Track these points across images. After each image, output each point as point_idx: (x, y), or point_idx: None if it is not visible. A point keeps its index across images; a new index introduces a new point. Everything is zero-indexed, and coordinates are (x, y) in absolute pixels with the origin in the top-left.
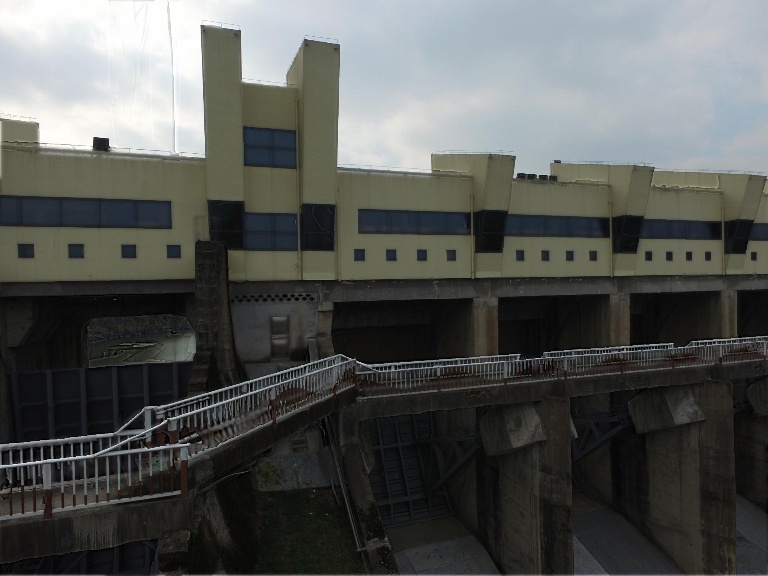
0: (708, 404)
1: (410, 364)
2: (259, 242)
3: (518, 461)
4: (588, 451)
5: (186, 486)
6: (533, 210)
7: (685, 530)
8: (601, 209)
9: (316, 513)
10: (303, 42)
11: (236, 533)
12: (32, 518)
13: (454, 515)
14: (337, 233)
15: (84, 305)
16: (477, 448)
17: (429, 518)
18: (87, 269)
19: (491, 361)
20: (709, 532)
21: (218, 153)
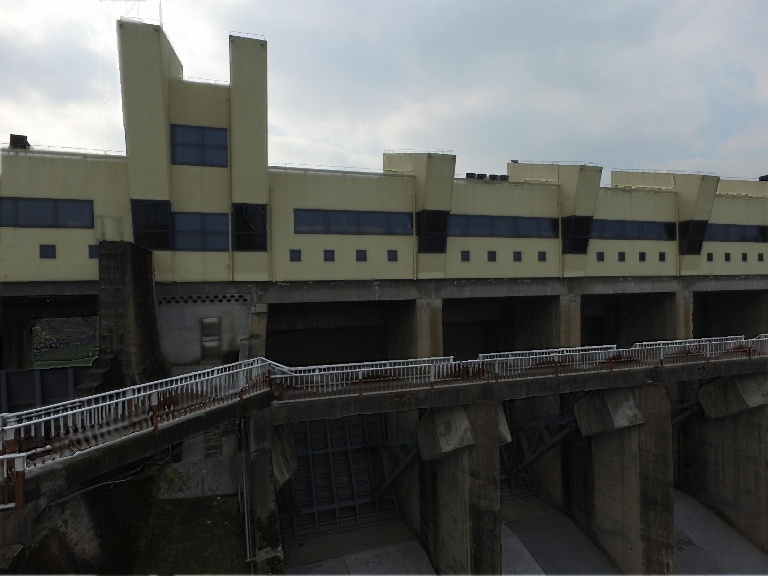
0: (647, 407)
1: (336, 367)
2: (188, 242)
3: (452, 465)
4: (538, 454)
5: (21, 498)
6: (479, 210)
7: (626, 534)
8: (550, 209)
9: (214, 521)
10: None
11: (110, 544)
12: None
13: (402, 519)
14: (271, 233)
15: (15, 306)
16: (416, 452)
17: (376, 522)
18: (3, 270)
19: None
20: (648, 537)
21: (140, 151)
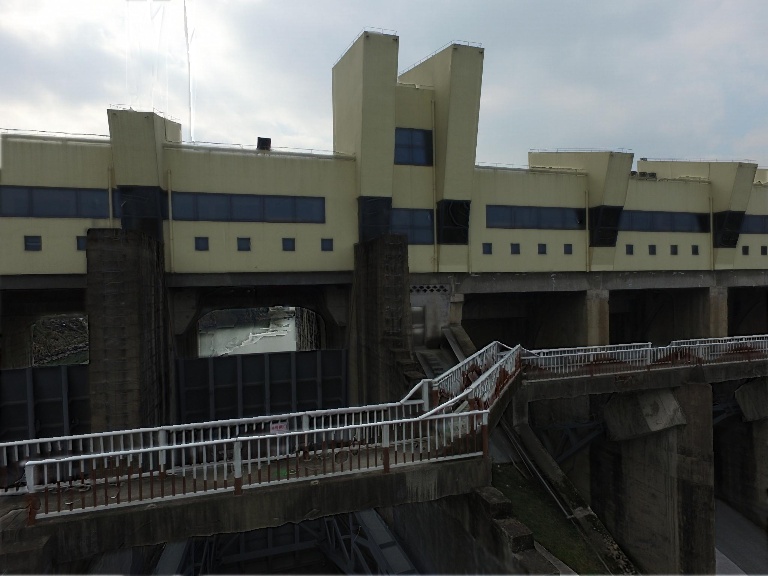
0: None
1: (556, 351)
2: None
3: (649, 445)
4: None
5: None
6: (641, 206)
7: None
8: (702, 205)
9: (511, 485)
10: (452, 46)
11: None
12: (372, 473)
13: None
14: (468, 228)
15: (222, 297)
16: (597, 434)
17: None
18: (253, 261)
19: (626, 349)
20: None
21: (372, 152)
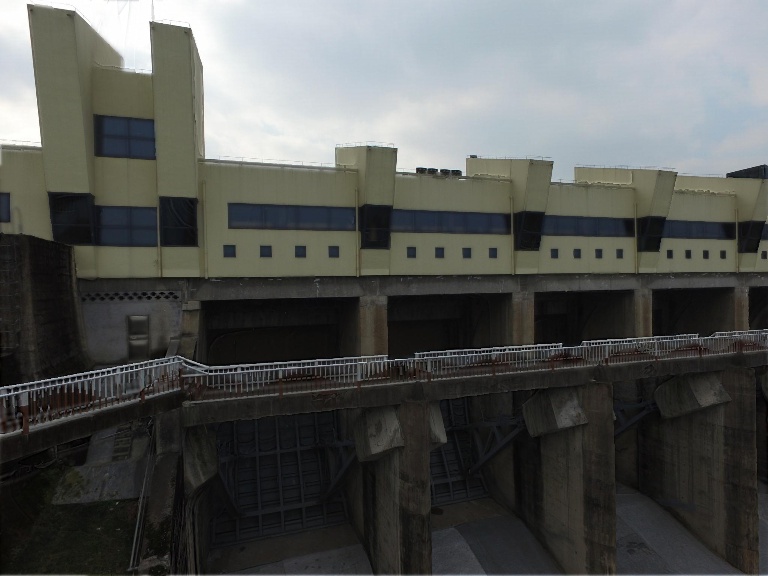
0: (590, 407)
1: (260, 366)
2: (114, 237)
3: (386, 467)
4: (491, 455)
5: None
6: (426, 205)
7: (572, 537)
8: (502, 205)
9: (105, 528)
10: None
11: None
12: None
13: (350, 522)
14: (203, 228)
15: None
16: None
17: (323, 525)
18: None
19: (354, 362)
20: (591, 540)
21: (57, 142)
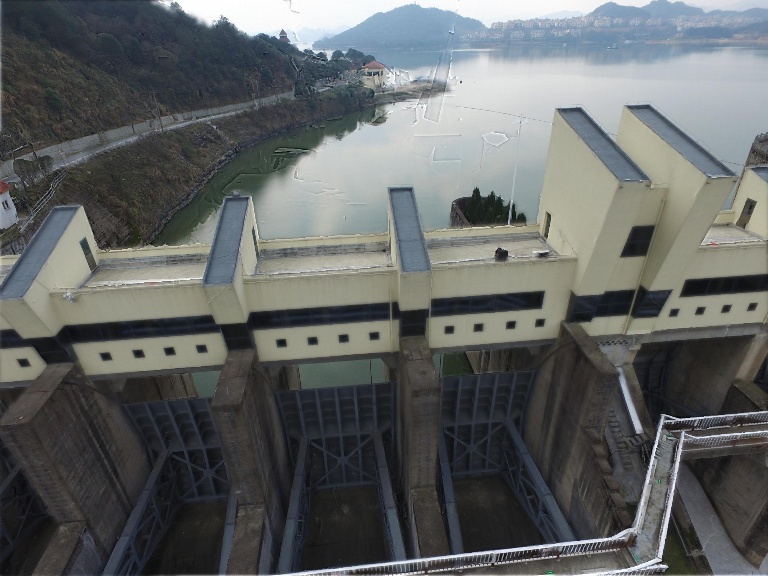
0: None
1: (710, 418)
2: (599, 310)
3: None
4: None
5: None
6: None
7: None
8: None
9: None
10: (705, 181)
11: None
12: None
13: None
14: None
15: None
16: None
17: None
18: (483, 337)
19: None
20: None
21: (596, 267)
